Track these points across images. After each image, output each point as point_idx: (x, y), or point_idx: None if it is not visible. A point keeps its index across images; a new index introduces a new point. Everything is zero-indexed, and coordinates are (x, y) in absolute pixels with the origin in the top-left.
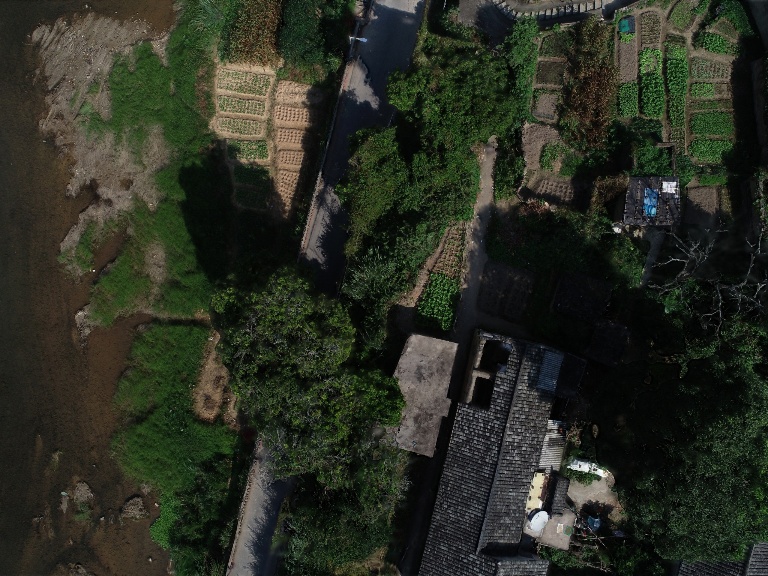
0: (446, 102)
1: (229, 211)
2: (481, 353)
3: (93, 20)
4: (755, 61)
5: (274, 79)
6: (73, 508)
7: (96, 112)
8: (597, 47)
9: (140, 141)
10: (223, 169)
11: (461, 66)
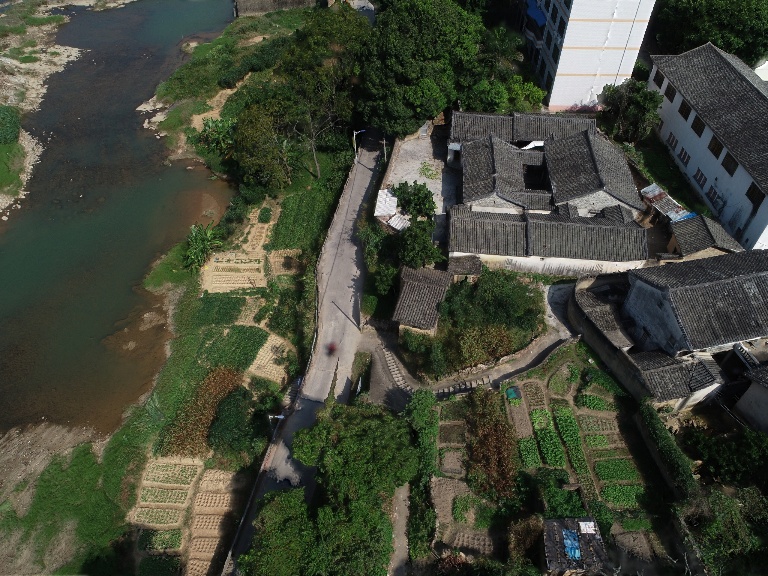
0: (348, 453)
1: None
2: None
3: (45, 428)
4: (635, 414)
5: (201, 469)
6: None
7: (13, 510)
8: (490, 409)
9: (48, 538)
10: (129, 562)
11: (363, 424)
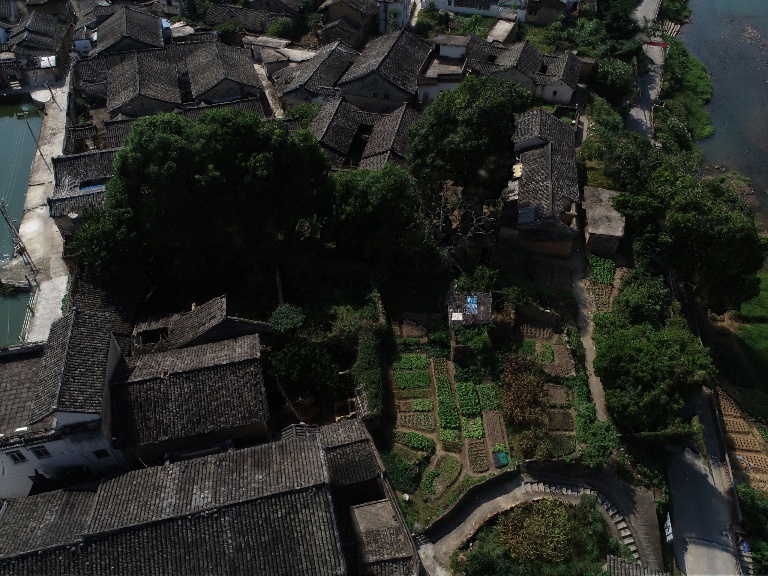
0: None
1: (766, 389)
2: (574, 224)
3: None
4: None
5: None
6: (767, 229)
7: None
8: None
9: None
10: None
11: None
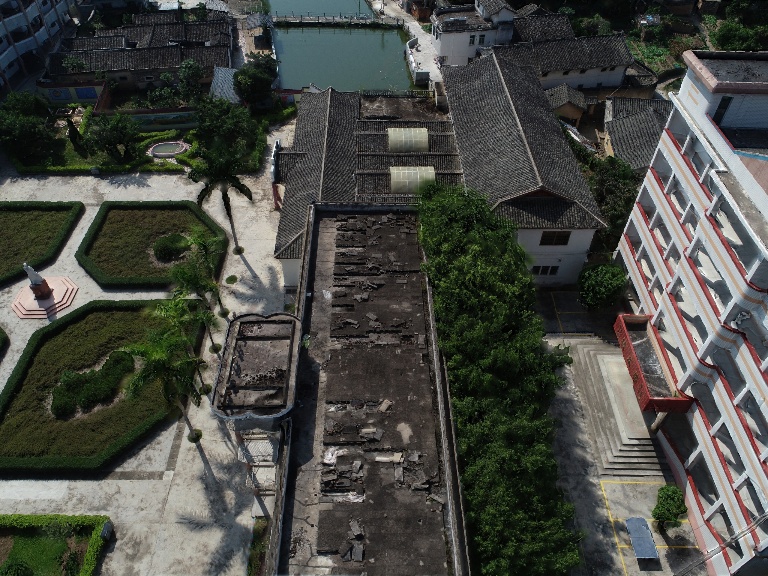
0: None
1: None
2: None
3: None
4: None
5: None
6: None
7: None
8: None
9: None
10: None
11: None
